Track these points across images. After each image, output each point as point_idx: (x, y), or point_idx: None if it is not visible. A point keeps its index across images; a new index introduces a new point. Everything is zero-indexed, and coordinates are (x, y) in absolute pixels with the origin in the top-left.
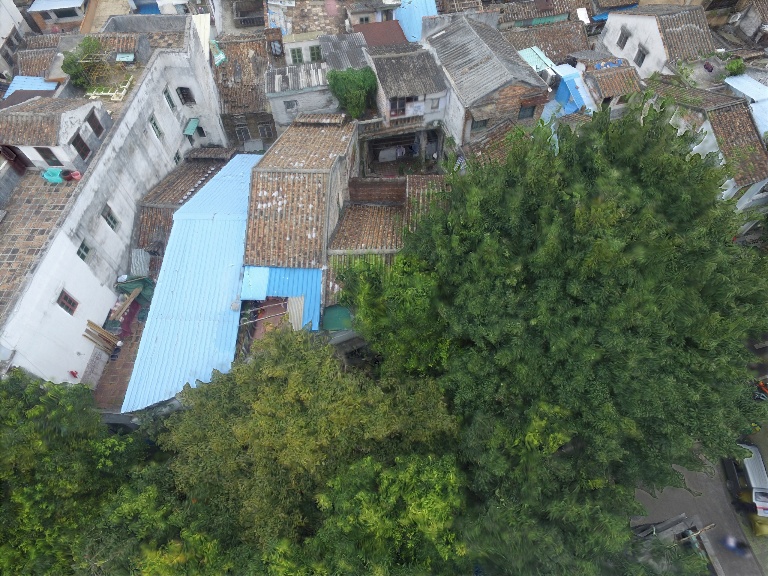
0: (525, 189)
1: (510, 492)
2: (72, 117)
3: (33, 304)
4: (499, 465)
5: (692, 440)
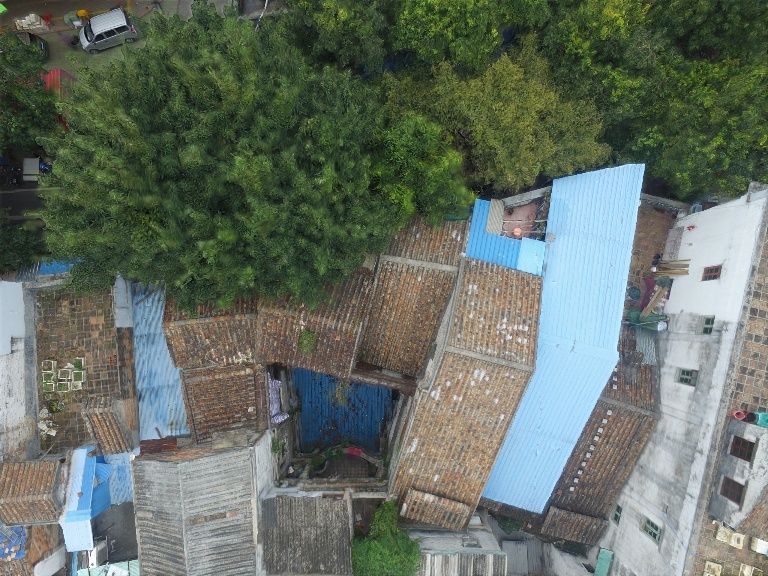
0: (272, 179)
1: (366, 3)
2: (764, 475)
3: (744, 245)
4: (369, 13)
5: (224, 6)
